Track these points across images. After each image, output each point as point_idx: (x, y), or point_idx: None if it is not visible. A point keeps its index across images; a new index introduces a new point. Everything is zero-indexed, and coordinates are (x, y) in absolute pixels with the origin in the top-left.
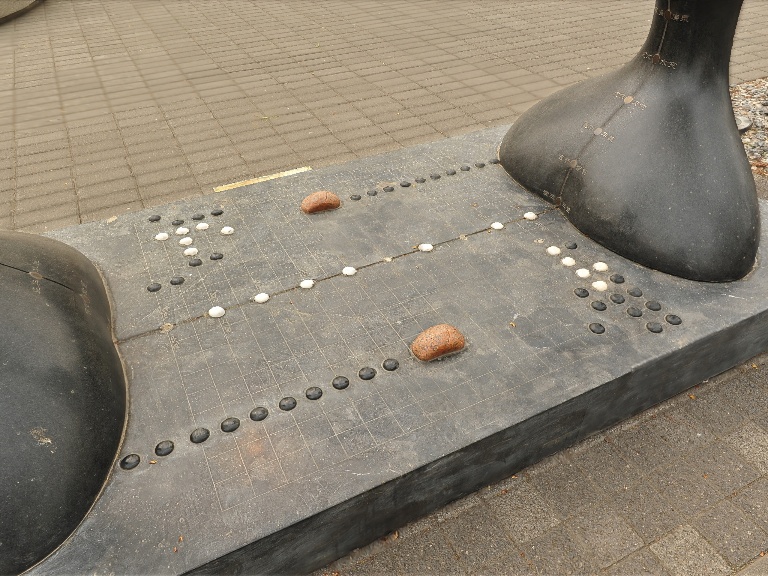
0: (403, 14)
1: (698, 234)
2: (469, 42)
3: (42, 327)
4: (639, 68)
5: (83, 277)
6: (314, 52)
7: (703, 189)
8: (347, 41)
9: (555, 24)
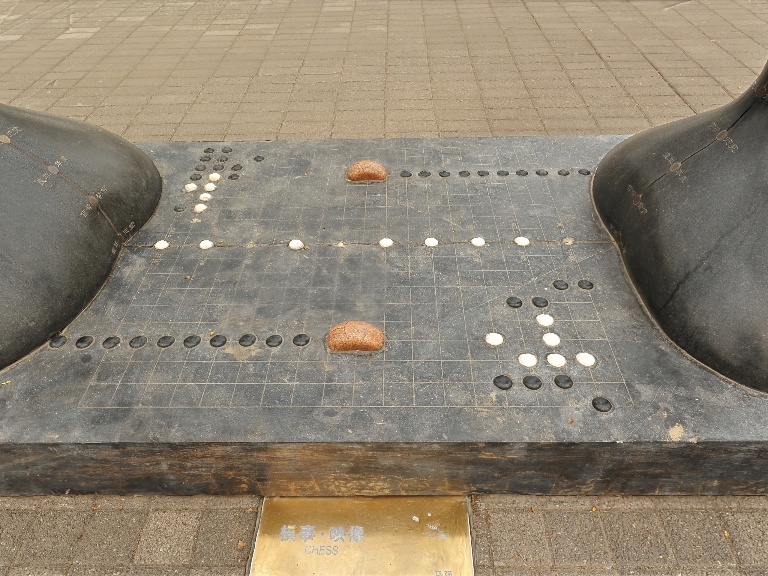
0: None
1: None
2: None
3: (650, 142)
4: None
5: (648, 220)
6: None
7: (93, 126)
8: None
9: None
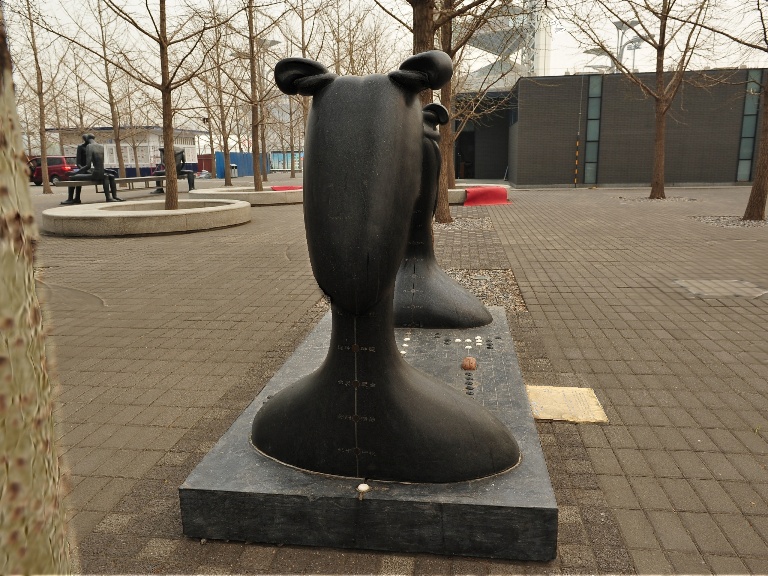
0: None
1: None
2: None
3: None
4: None
5: (427, 307)
6: None
7: None
8: None
9: None
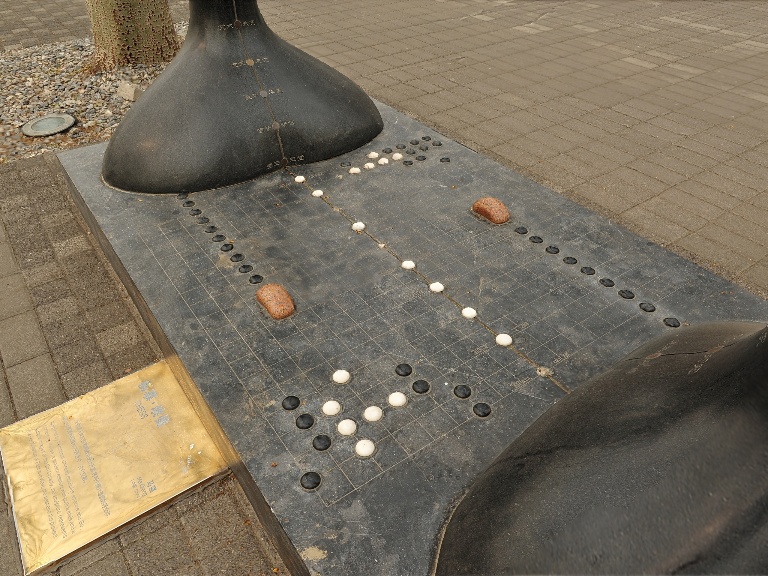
0: None
1: (366, 104)
2: None
3: None
4: (228, 39)
5: None
6: None
7: (342, 81)
8: None
9: None
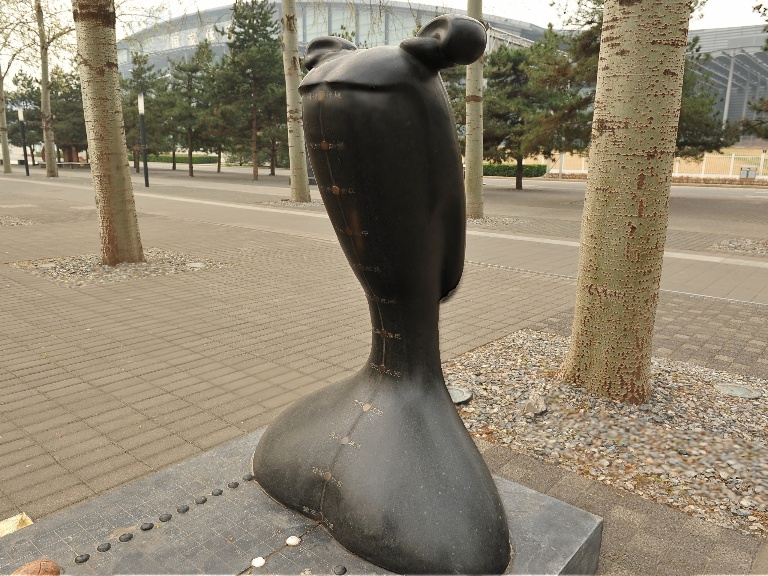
0: (144, 315)
1: (456, 535)
2: (214, 339)
3: None
4: (370, 377)
5: None
6: (40, 364)
7: (449, 488)
8: (81, 348)
9: (294, 316)
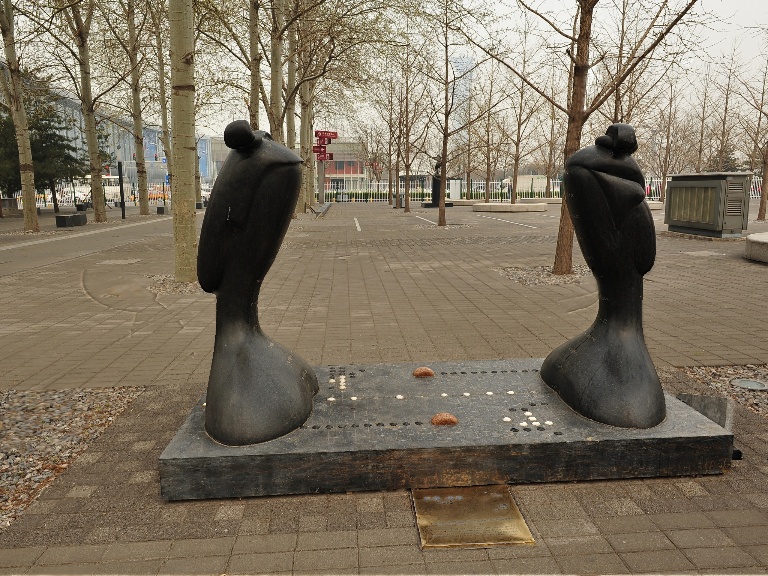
0: None
1: None
2: None
3: None
4: None
5: (566, 373)
6: None
7: None
8: None
9: None
